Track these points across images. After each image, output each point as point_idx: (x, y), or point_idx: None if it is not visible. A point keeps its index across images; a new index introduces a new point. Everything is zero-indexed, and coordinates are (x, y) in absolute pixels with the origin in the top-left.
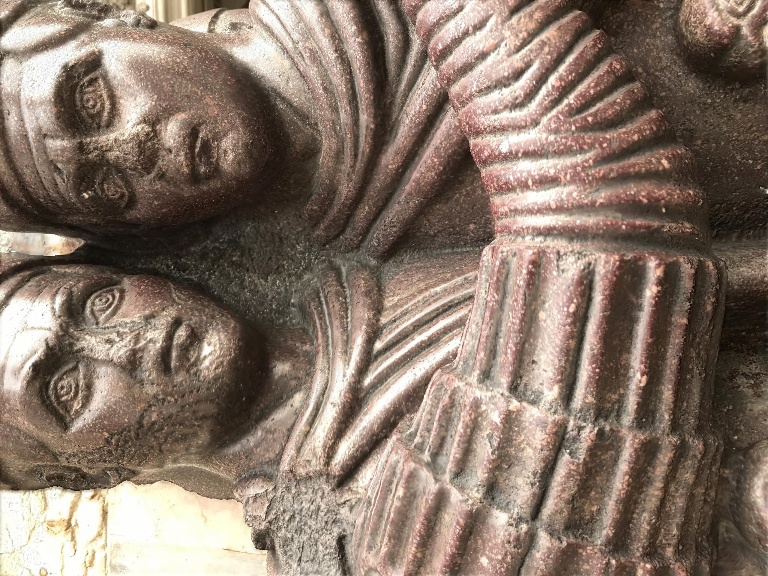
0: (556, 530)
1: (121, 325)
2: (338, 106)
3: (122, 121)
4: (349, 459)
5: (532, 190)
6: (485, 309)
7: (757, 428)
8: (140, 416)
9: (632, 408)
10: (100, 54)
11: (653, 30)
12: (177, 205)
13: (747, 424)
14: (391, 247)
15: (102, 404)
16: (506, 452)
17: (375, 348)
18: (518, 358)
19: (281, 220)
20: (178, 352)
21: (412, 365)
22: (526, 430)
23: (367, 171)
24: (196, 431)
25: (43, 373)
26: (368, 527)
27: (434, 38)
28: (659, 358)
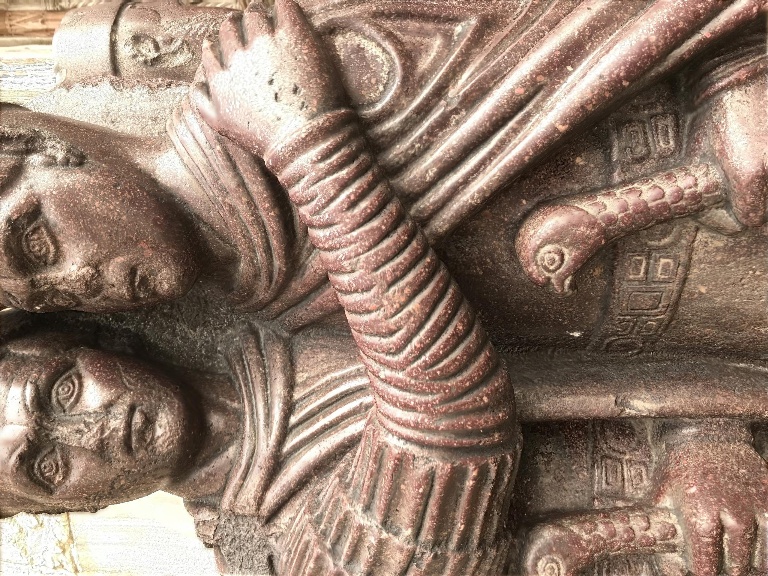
0: None
1: (85, 414)
2: (255, 248)
3: (67, 261)
4: (274, 506)
5: (399, 408)
6: (367, 468)
7: (542, 497)
8: (111, 483)
9: (454, 541)
10: (39, 203)
11: (499, 235)
12: (120, 310)
13: (537, 494)
14: (300, 327)
15: (80, 477)
16: (379, 558)
17: (290, 423)
18: (387, 508)
19: (206, 289)
20: (137, 437)
21: (318, 443)
22: (391, 550)
23: (280, 290)
24: (155, 485)
25: (28, 459)
26: (290, 567)
27: (333, 276)
28: (472, 513)
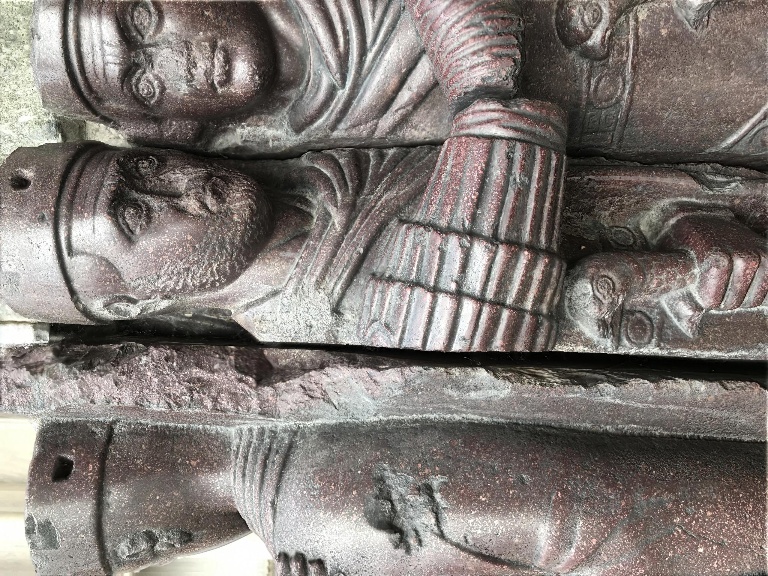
0: None
1: None
2: None
3: None
4: None
5: None
6: None
7: None
8: None
9: None
10: None
11: None
12: None
13: None
14: None
15: None
16: None
17: None
18: None
19: None
20: None
21: None
22: None
23: None
24: None
25: None
26: None
27: None
28: None
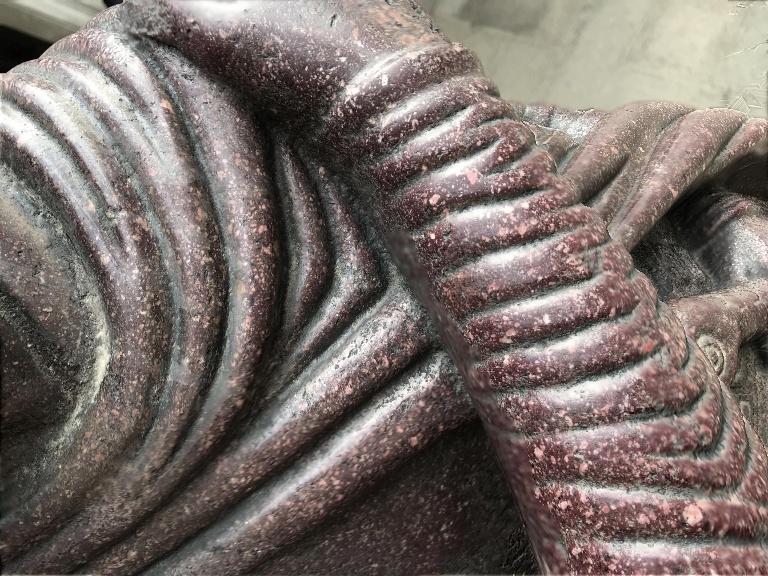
0: None
1: None
2: (172, 349)
3: None
4: None
5: None
6: None
7: None
8: None
9: None
10: None
11: None
12: None
13: None
14: None
15: None
16: None
17: None
18: None
19: None
20: None
21: None
22: None
23: (181, 483)
24: None
25: None
26: None
27: (525, 303)
28: None
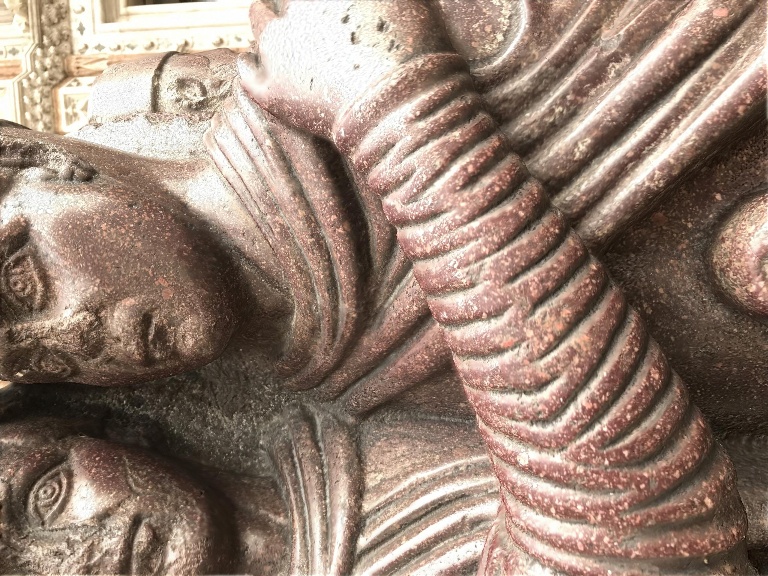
0: None
1: (71, 528)
2: (314, 287)
3: (59, 305)
4: None
5: (555, 518)
6: None
7: None
8: None
9: None
10: (27, 225)
11: (678, 250)
12: (129, 380)
13: None
14: (371, 409)
15: None
16: None
17: (358, 547)
18: None
19: (246, 360)
20: (139, 564)
21: None
22: None
23: (347, 349)
24: None
25: None
26: None
27: (437, 300)
28: None
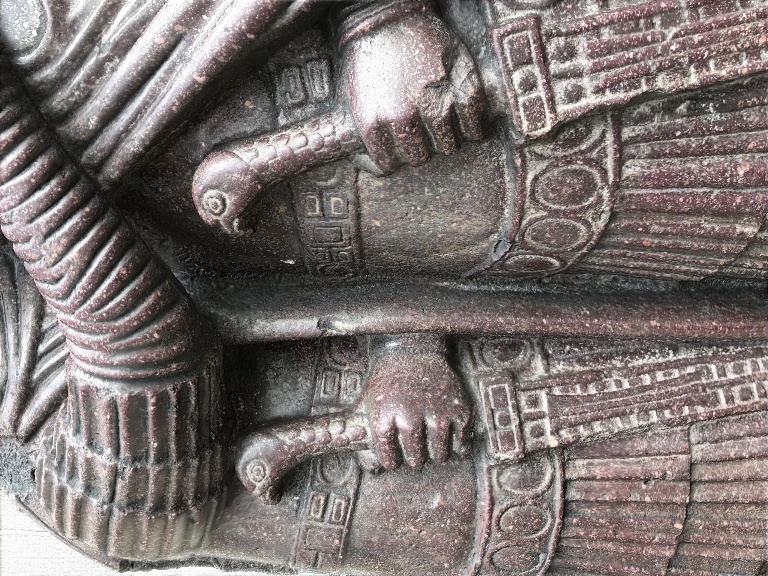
0: (123, 507)
1: None
2: None
3: None
4: (30, 427)
5: (79, 347)
6: None
7: (268, 407)
8: None
9: (152, 456)
10: None
11: (187, 176)
12: None
13: (264, 405)
14: None
15: None
16: (91, 473)
17: (38, 352)
18: (88, 432)
19: None
20: None
21: (63, 369)
22: (98, 467)
23: None
24: None
25: None
26: None
27: None
28: (164, 432)
